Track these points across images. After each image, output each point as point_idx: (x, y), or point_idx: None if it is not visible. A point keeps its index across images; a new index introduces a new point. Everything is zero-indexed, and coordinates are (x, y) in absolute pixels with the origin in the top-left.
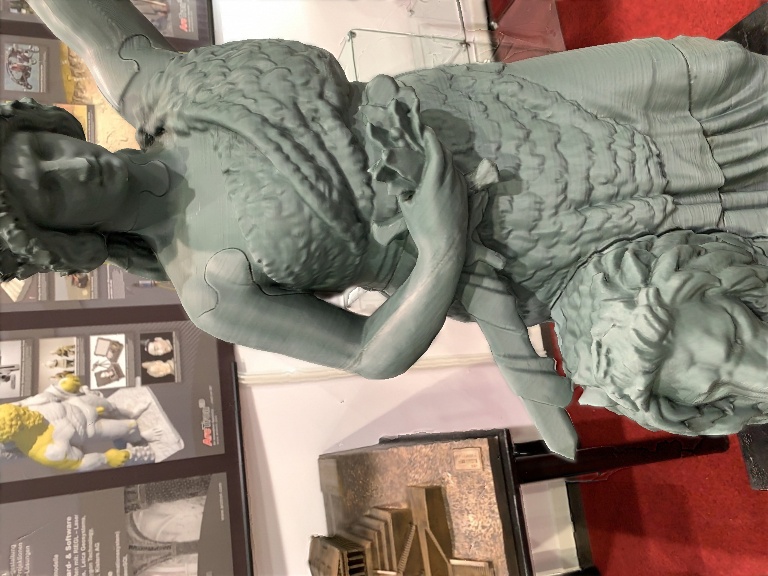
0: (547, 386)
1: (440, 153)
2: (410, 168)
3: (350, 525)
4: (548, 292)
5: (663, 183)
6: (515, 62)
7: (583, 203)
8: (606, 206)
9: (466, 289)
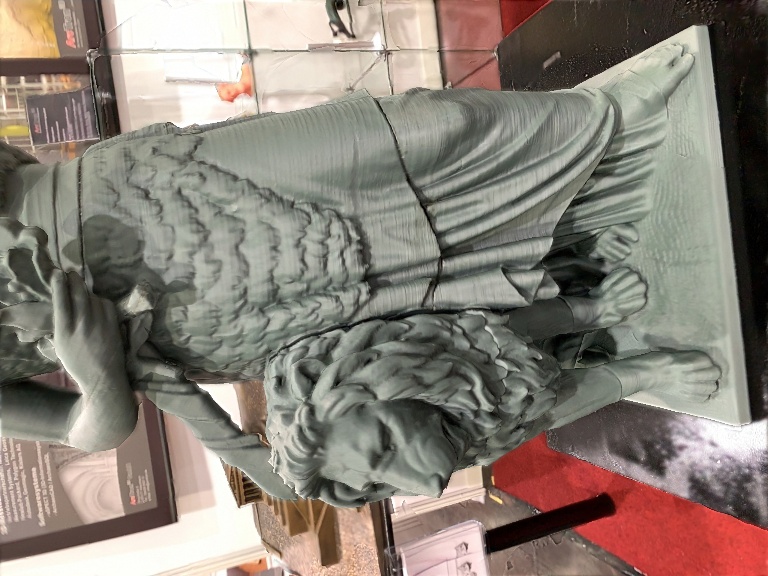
0: (251, 457)
1: (63, 307)
2: (34, 322)
3: (251, 425)
4: (254, 371)
5: (360, 272)
6: (214, 136)
7: (268, 303)
8: (292, 305)
9: (147, 393)
